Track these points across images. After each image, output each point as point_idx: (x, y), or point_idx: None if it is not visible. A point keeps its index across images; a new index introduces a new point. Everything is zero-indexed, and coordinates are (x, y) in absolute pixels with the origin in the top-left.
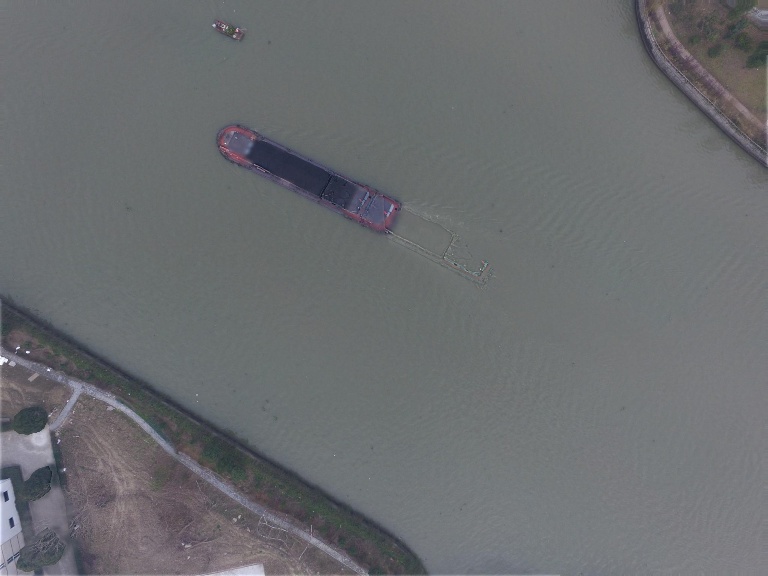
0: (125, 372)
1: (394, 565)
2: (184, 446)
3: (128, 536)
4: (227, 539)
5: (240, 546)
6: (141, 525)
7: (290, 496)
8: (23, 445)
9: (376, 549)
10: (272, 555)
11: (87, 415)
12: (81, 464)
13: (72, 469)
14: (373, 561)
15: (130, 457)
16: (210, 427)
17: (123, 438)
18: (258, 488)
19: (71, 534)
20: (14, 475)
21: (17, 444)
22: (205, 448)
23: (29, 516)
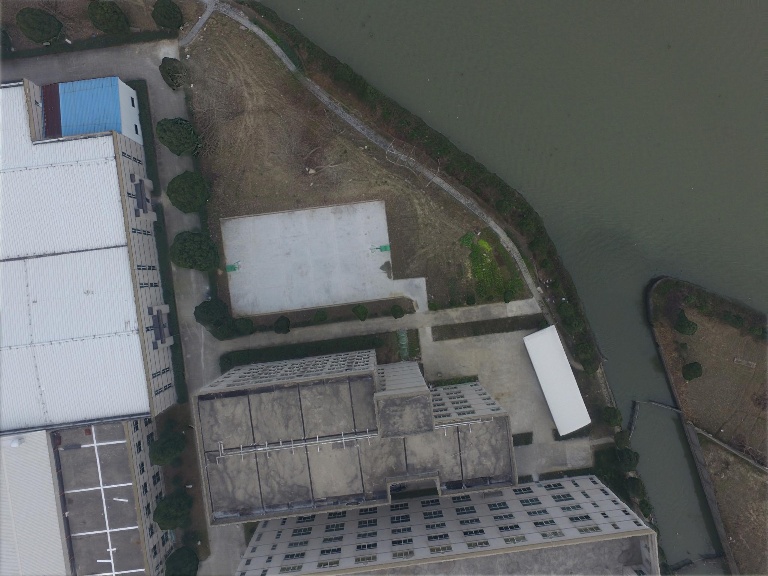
0: None
1: (516, 214)
2: (314, 74)
3: (255, 151)
4: (353, 165)
5: (366, 174)
6: (269, 140)
7: (417, 135)
8: (150, 60)
9: (499, 196)
10: (396, 188)
11: (220, 30)
12: (211, 75)
13: (200, 84)
14: (495, 207)
15: (262, 72)
16: None
17: (256, 54)
18: (385, 124)
19: (194, 152)
20: (140, 87)
21: (144, 58)
22: None
23: (151, 132)
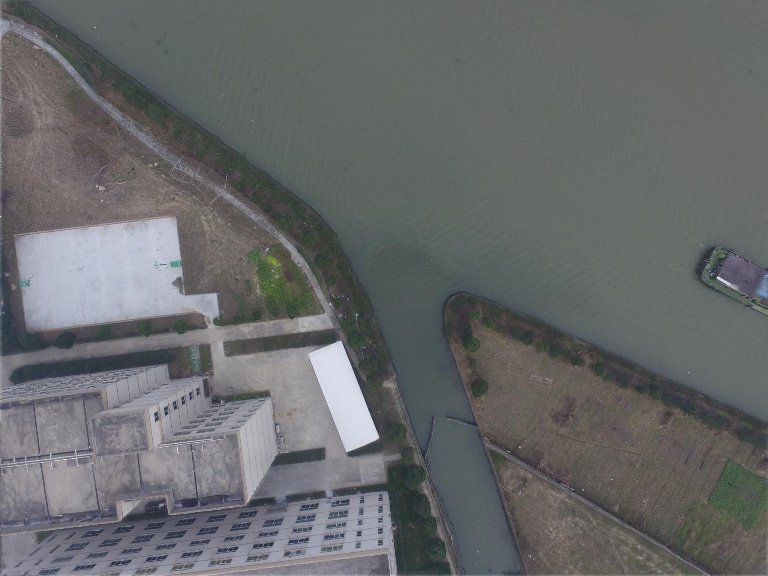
0: (56, 22)
1: (307, 230)
2: (107, 92)
3: (42, 168)
4: (141, 182)
5: (153, 190)
6: (56, 158)
7: (209, 152)
8: None
9: (291, 212)
10: (185, 205)
11: (12, 49)
12: (1, 94)
13: None
14: None
15: (51, 91)
16: (135, 80)
17: (45, 73)
18: (177, 141)
19: None
20: None
21: None
22: None
23: None
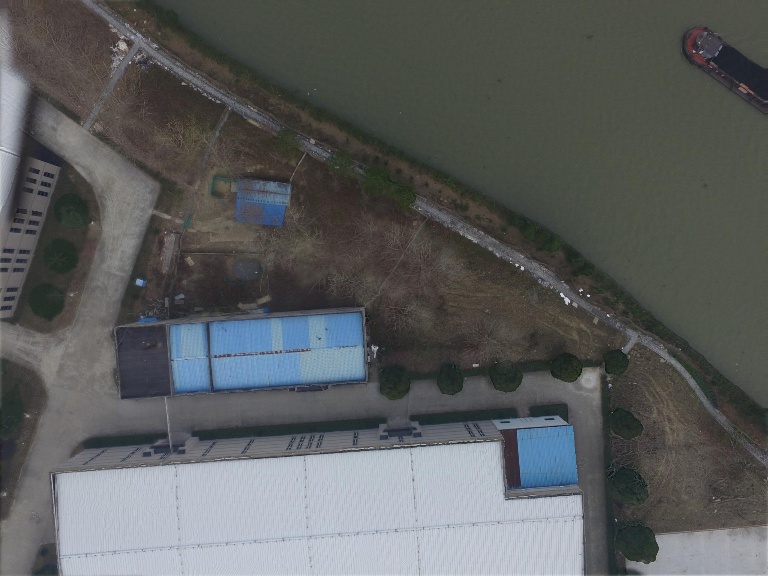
0: None
1: None
2: (722, 405)
3: (673, 484)
4: (758, 498)
5: None
6: (687, 475)
7: None
8: (572, 385)
9: None
10: None
11: (644, 364)
12: (637, 410)
13: None
14: None
15: (684, 409)
16: None
17: (678, 390)
18: None
19: (609, 476)
20: (564, 412)
21: (567, 383)
22: (742, 410)
23: None
